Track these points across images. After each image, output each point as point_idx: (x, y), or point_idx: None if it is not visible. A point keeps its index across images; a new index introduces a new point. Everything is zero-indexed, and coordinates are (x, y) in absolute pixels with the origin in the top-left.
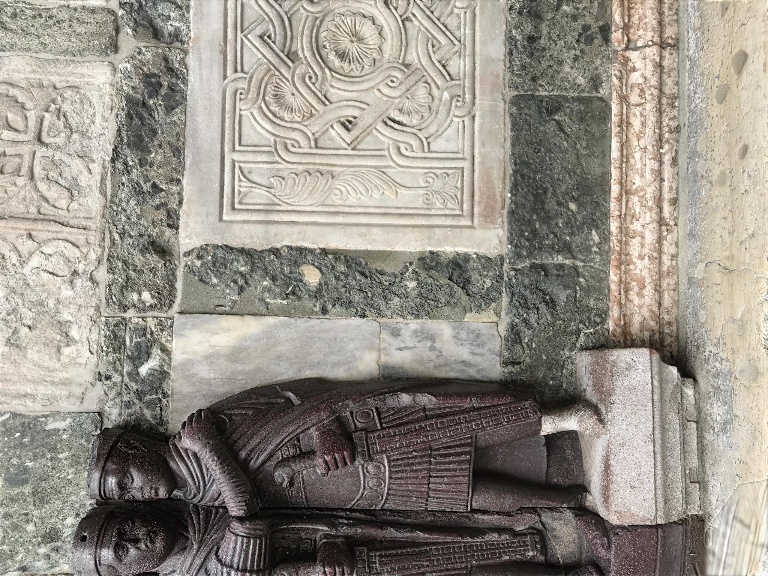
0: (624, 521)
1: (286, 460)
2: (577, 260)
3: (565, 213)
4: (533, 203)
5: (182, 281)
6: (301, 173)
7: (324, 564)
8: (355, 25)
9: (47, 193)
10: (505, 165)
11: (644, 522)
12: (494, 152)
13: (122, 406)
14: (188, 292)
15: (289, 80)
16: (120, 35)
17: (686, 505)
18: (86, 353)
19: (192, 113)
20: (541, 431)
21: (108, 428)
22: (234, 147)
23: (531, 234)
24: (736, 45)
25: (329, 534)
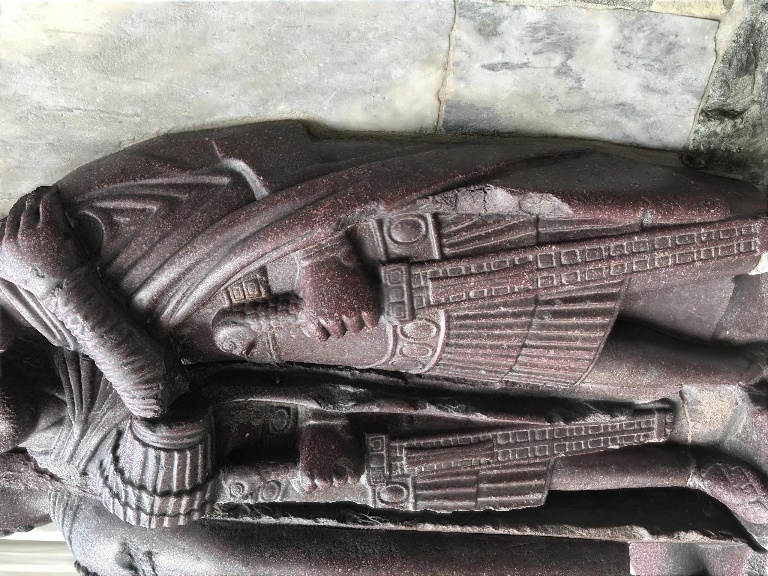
0: None
1: (238, 312)
2: None
3: None
4: None
5: None
6: None
7: (313, 473)
8: None
9: None
10: None
11: None
12: None
13: None
14: None
15: None
16: None
17: None
18: None
19: None
20: (753, 270)
21: None
22: None
23: None
24: None
25: (321, 411)
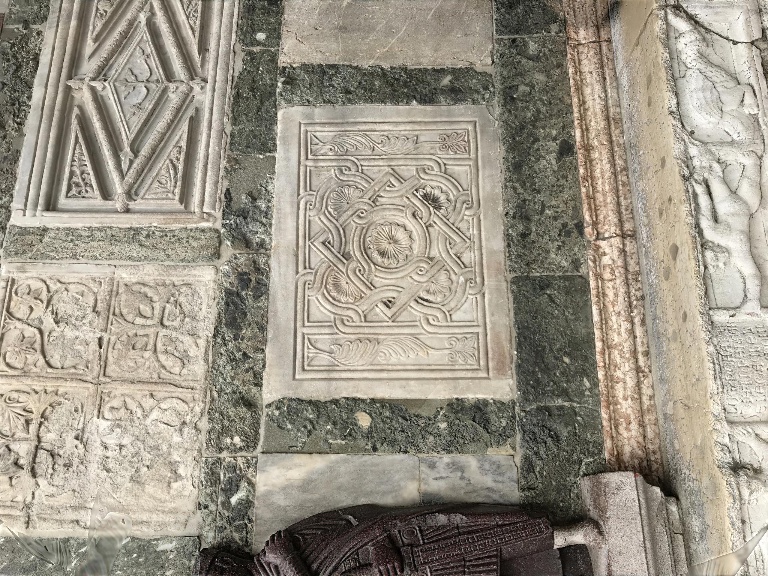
0: None
1: (348, 571)
2: (574, 402)
3: (561, 365)
4: (535, 358)
5: (264, 427)
6: (354, 341)
7: None
8: (391, 231)
9: (165, 363)
10: (511, 329)
11: None
12: (501, 320)
13: (216, 530)
14: (269, 436)
15: (344, 273)
16: (222, 246)
17: None
18: (190, 487)
19: (273, 300)
20: (554, 545)
21: (206, 548)
22: (304, 323)
23: (535, 382)
24: (670, 240)
25: None
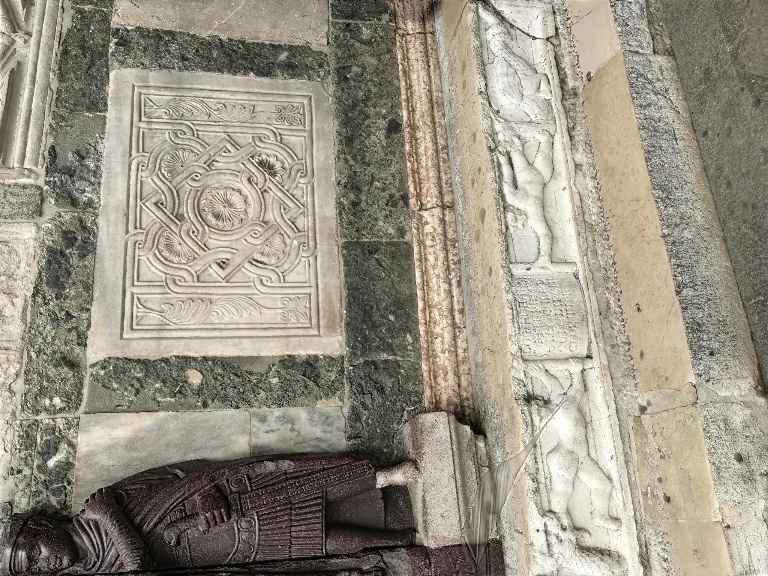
0: (439, 543)
1: (174, 522)
2: (398, 356)
3: (386, 323)
4: (363, 316)
5: (88, 388)
6: (186, 301)
7: None
8: (227, 195)
9: None
10: (341, 290)
11: (454, 542)
12: (332, 281)
13: (31, 495)
14: (92, 396)
15: (177, 234)
16: (44, 204)
17: None
18: (1, 451)
19: (100, 259)
20: (376, 484)
21: (18, 513)
22: (133, 283)
23: (363, 339)
24: (480, 205)
25: None
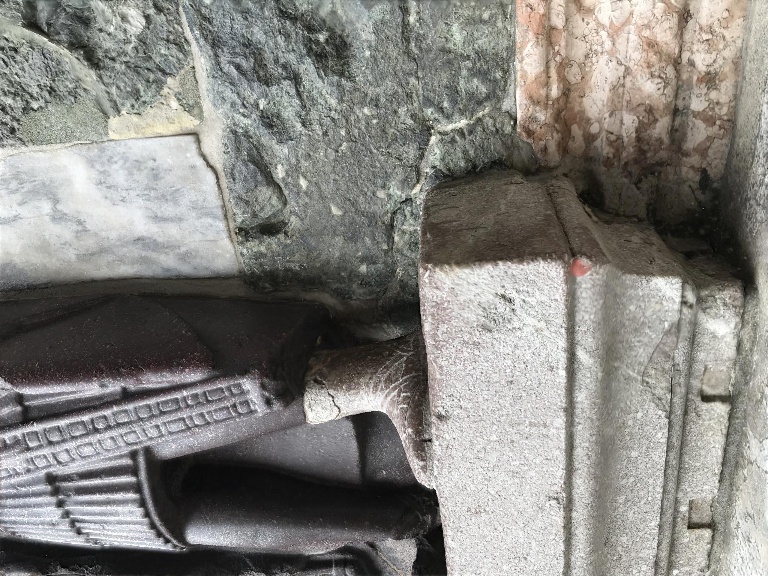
0: None
1: None
2: None
3: None
4: None
5: None
6: None
7: None
8: None
9: None
10: None
11: None
12: None
13: None
14: None
15: None
16: None
17: (669, 569)
18: None
19: None
20: (307, 421)
21: None
22: None
23: None
24: None
25: None
